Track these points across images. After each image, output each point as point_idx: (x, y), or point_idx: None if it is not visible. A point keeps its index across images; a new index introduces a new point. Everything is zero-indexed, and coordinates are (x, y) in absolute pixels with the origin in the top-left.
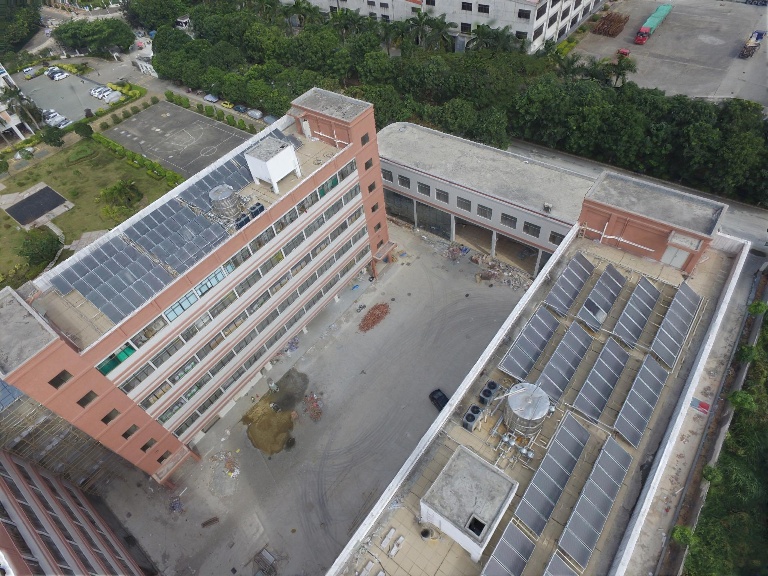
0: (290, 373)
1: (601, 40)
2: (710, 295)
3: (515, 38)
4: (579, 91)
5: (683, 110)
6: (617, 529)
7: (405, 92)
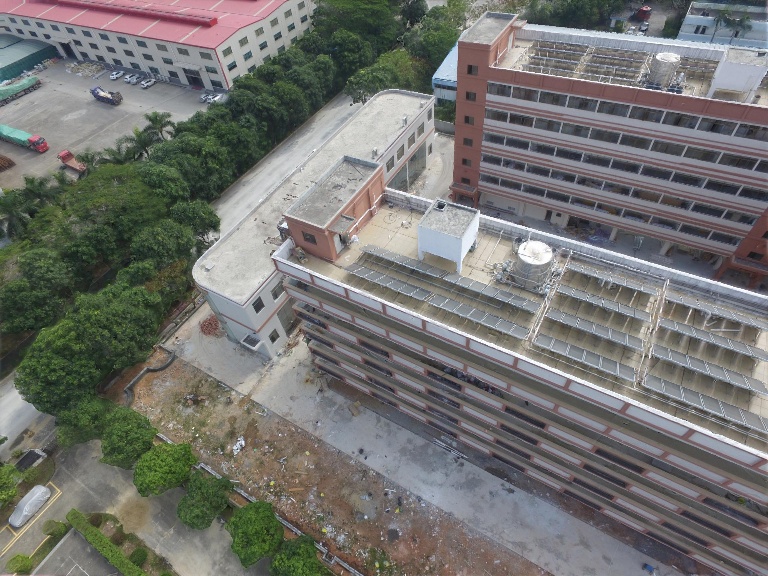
0: None
1: (12, 174)
2: (529, 42)
3: (47, 180)
4: (172, 153)
5: (239, 101)
6: None
7: (42, 322)
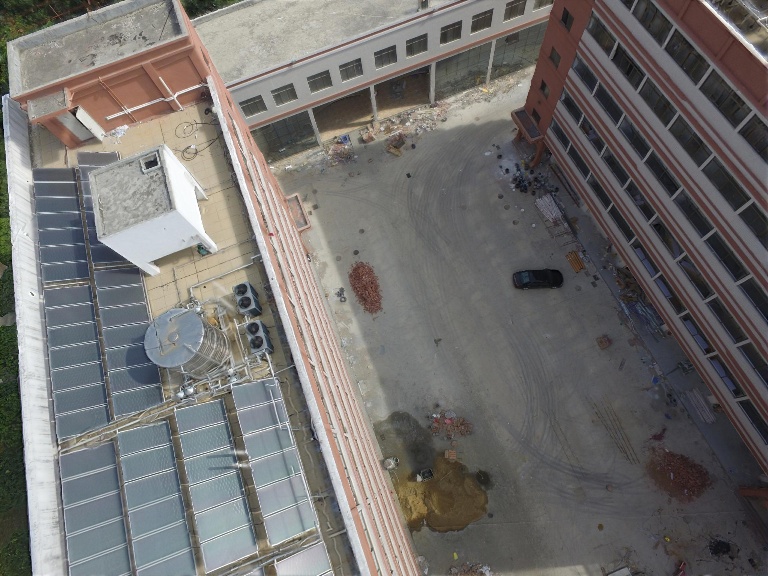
0: (379, 432)
1: None
2: None
3: None
4: None
5: None
6: None
7: None
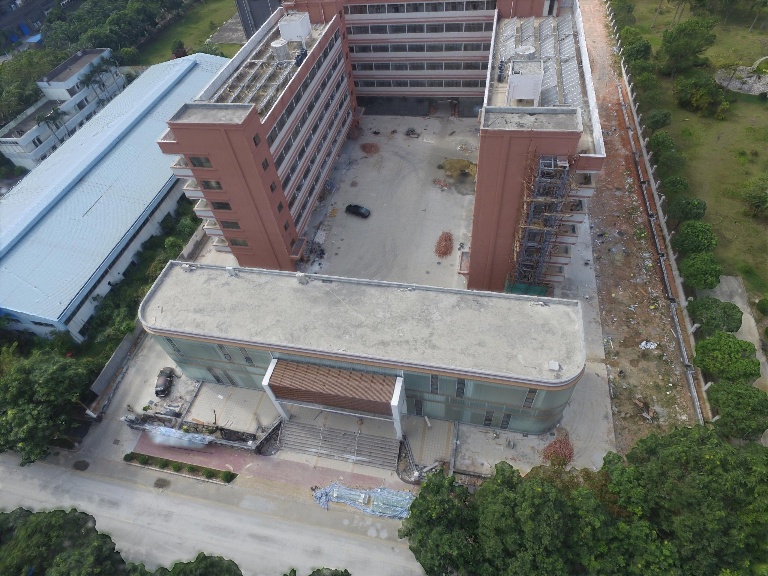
0: None
1: None
2: None
3: None
4: None
5: None
6: (248, 57)
7: None
